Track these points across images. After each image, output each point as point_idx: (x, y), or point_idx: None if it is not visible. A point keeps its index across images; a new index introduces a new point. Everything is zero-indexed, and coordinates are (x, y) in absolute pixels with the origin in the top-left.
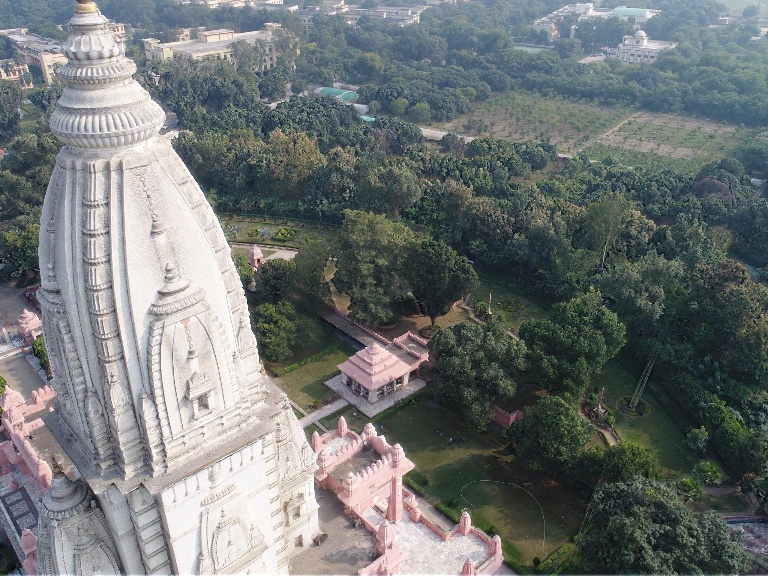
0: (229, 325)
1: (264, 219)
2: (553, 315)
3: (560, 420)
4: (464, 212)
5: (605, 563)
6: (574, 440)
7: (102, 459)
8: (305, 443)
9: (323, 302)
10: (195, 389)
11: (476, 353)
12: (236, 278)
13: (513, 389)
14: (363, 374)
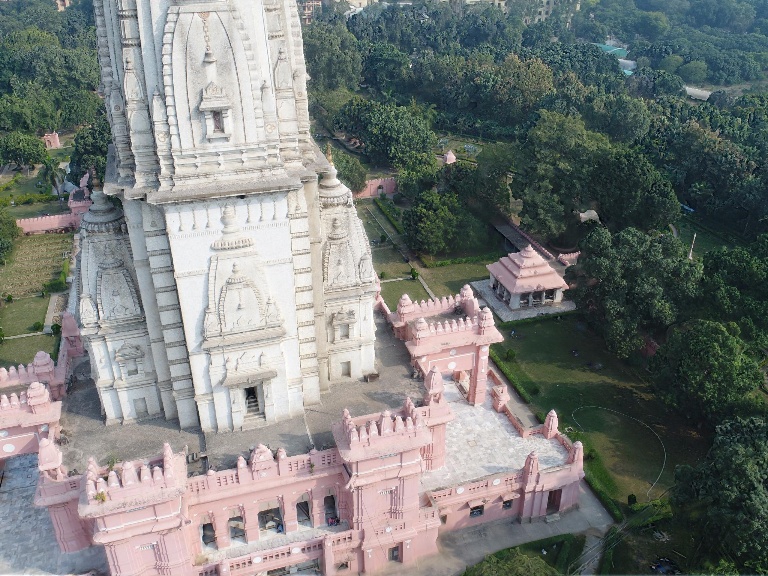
0: (263, 48)
1: (477, 140)
2: (754, 247)
3: (712, 347)
4: (694, 150)
5: (697, 495)
6: (727, 379)
7: (121, 165)
8: (365, 255)
9: (498, 209)
10: (208, 101)
11: (633, 262)
12: (293, 14)
13: (672, 316)
14: (509, 276)
